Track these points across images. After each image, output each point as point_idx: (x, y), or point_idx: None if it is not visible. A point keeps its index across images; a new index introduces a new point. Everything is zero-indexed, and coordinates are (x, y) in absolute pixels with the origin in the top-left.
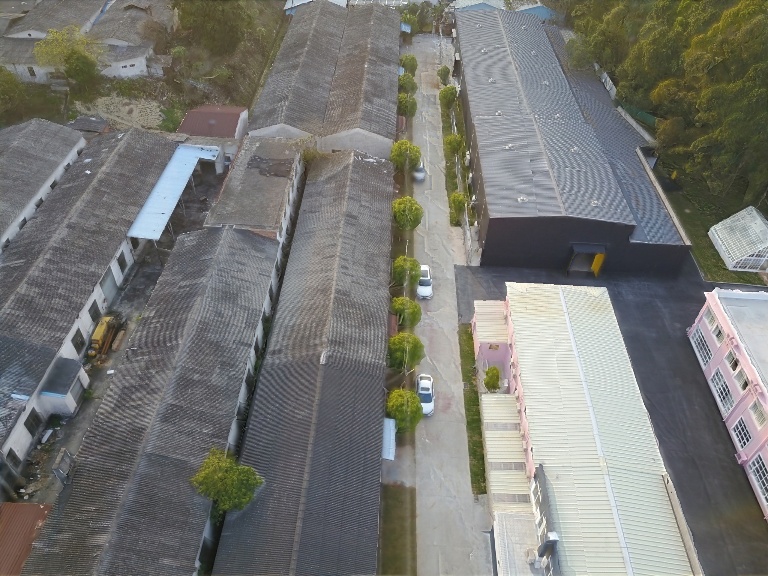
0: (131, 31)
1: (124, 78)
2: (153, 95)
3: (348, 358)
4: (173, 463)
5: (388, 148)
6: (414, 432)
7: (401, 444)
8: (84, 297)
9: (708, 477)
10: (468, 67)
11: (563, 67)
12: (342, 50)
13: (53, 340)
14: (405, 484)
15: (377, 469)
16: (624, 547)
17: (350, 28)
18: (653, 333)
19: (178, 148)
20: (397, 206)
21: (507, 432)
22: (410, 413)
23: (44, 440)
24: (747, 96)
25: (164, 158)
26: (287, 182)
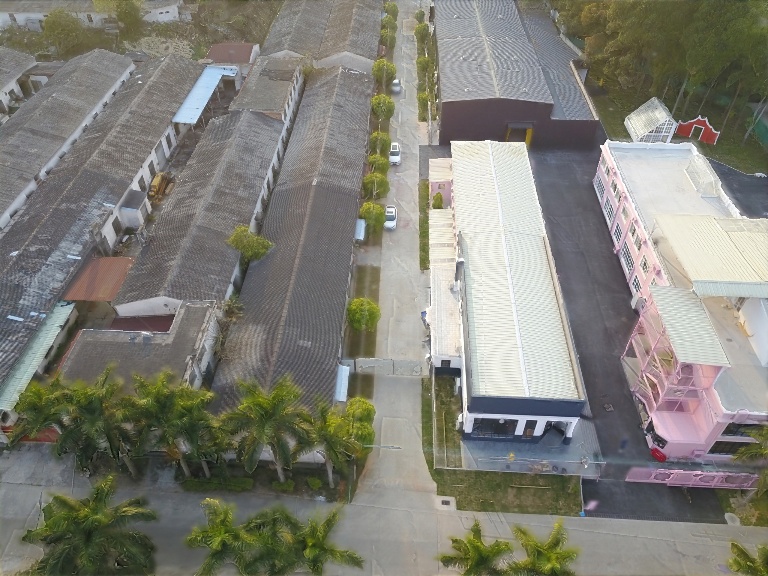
0: None
1: (161, 23)
2: (184, 35)
3: (332, 184)
4: (214, 232)
5: (371, 68)
6: (381, 238)
7: (372, 245)
8: (145, 154)
9: (591, 262)
10: (438, 8)
11: (519, 8)
12: (336, 1)
13: (127, 177)
14: (373, 265)
15: (350, 241)
16: (508, 266)
17: None
18: (566, 182)
19: (206, 68)
20: (374, 100)
21: (444, 228)
22: (375, 214)
23: (124, 240)
24: (640, 4)
25: (196, 74)
26: (290, 84)
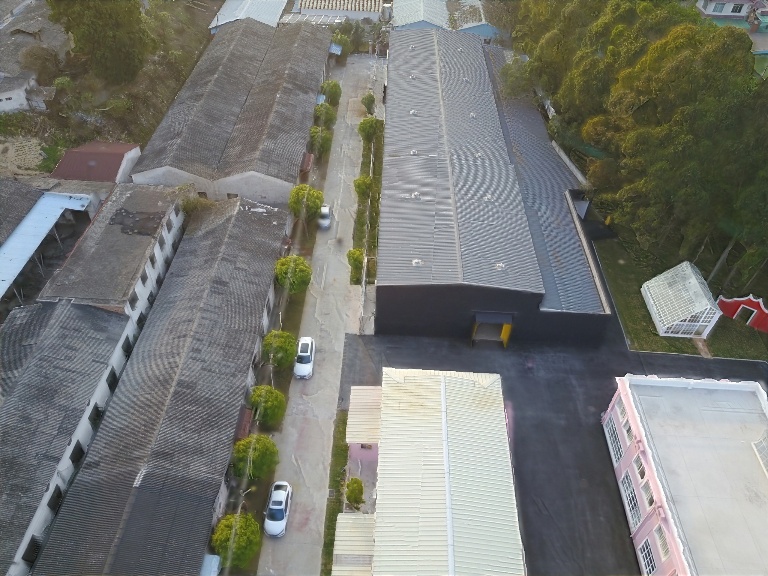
0: (11, 60)
1: (0, 113)
2: (33, 131)
3: (173, 475)
4: None
5: (289, 192)
6: (258, 559)
7: None
8: None
9: None
10: (391, 96)
11: (499, 94)
12: (259, 76)
13: None
14: None
15: None
16: None
17: (273, 50)
18: (562, 420)
19: (43, 197)
20: (278, 268)
21: (358, 568)
22: (236, 550)
23: None
24: (673, 143)
25: (22, 210)
26: (150, 242)
